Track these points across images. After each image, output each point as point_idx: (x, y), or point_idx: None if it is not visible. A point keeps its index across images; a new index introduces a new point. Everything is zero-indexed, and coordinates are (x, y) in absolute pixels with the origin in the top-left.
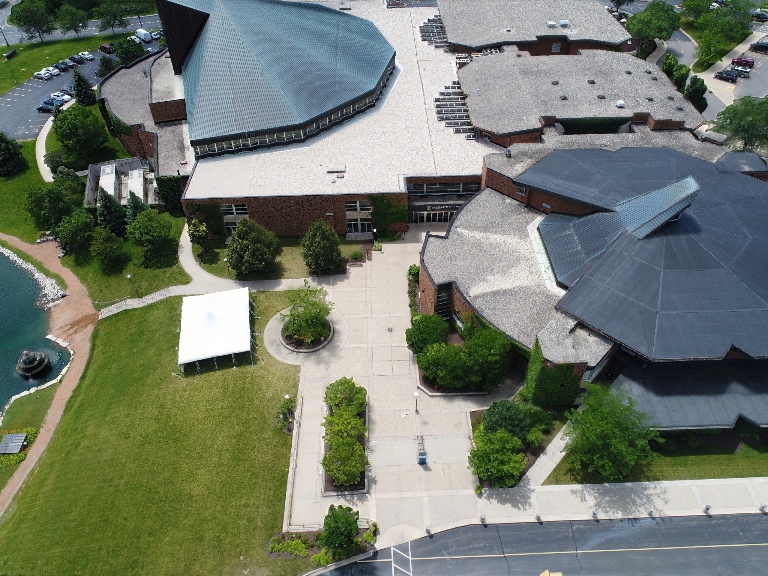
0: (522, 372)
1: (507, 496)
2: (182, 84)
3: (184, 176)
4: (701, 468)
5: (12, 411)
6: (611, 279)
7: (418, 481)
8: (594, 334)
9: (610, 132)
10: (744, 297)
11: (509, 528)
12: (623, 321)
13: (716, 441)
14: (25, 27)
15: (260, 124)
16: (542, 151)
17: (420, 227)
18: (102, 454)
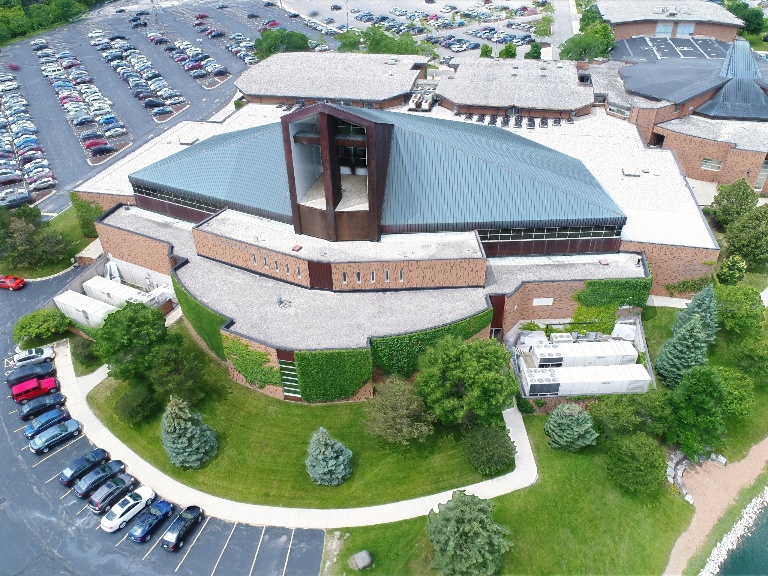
0: None
1: None
2: (420, 235)
3: None
4: None
5: None
6: None
7: None
8: None
9: None
10: None
11: None
12: None
13: None
14: None
15: (588, 176)
16: None
17: None
18: None
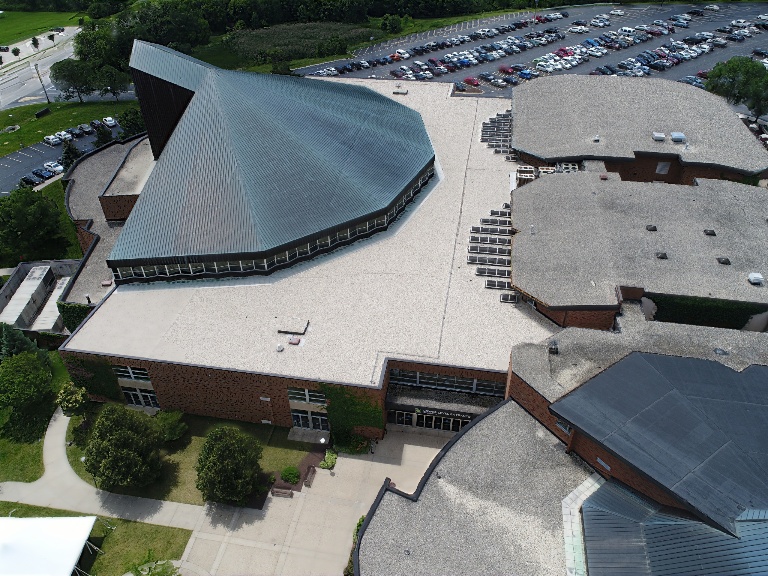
0: None
1: None
2: None
3: (93, 306)
4: None
5: None
6: None
7: None
8: None
9: (734, 321)
10: None
11: None
12: None
13: None
14: (61, 86)
15: (207, 246)
16: (612, 348)
17: (405, 433)
18: None
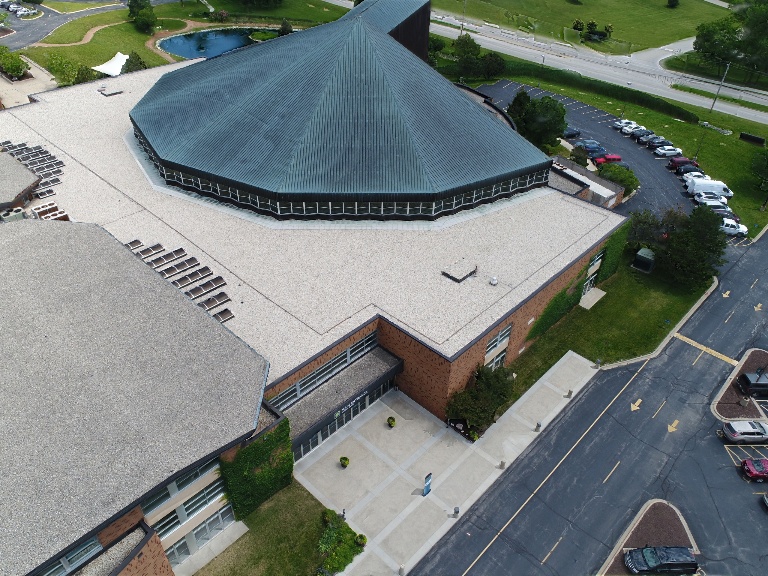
0: None
1: None
2: None
3: None
4: None
5: None
6: None
7: None
8: None
9: None
10: None
11: None
12: None
13: None
14: None
15: None
16: None
17: None
18: None
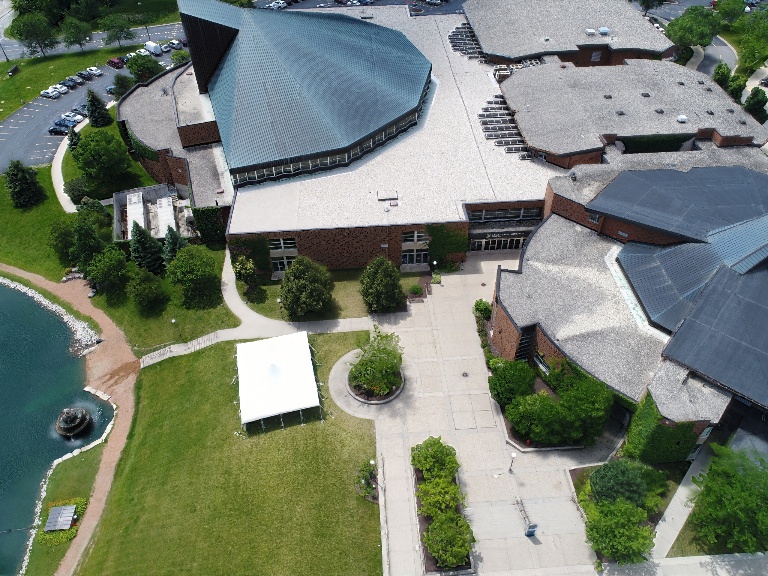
0: (618, 421)
1: (630, 572)
2: (209, 104)
3: (223, 207)
4: None
5: (56, 478)
6: (718, 321)
7: (529, 557)
8: (708, 384)
9: (672, 149)
10: None
11: None
12: (741, 370)
13: None
14: (27, 42)
15: (303, 149)
16: (608, 173)
17: (478, 256)
18: (167, 531)
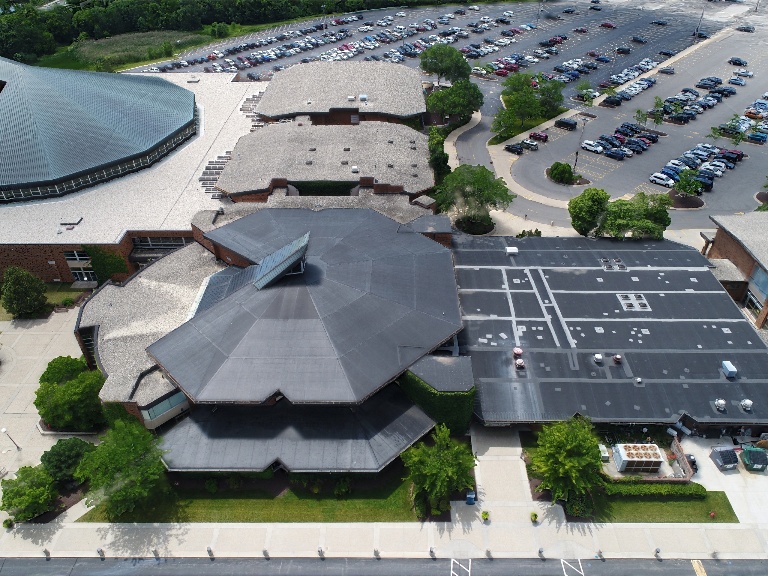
0: None
1: (34, 531)
2: None
3: None
4: (234, 511)
5: None
6: (209, 325)
7: None
8: None
9: (343, 195)
10: (319, 346)
11: (15, 562)
12: (193, 364)
13: (264, 486)
14: None
15: (14, 179)
16: (257, 210)
17: None
18: None
